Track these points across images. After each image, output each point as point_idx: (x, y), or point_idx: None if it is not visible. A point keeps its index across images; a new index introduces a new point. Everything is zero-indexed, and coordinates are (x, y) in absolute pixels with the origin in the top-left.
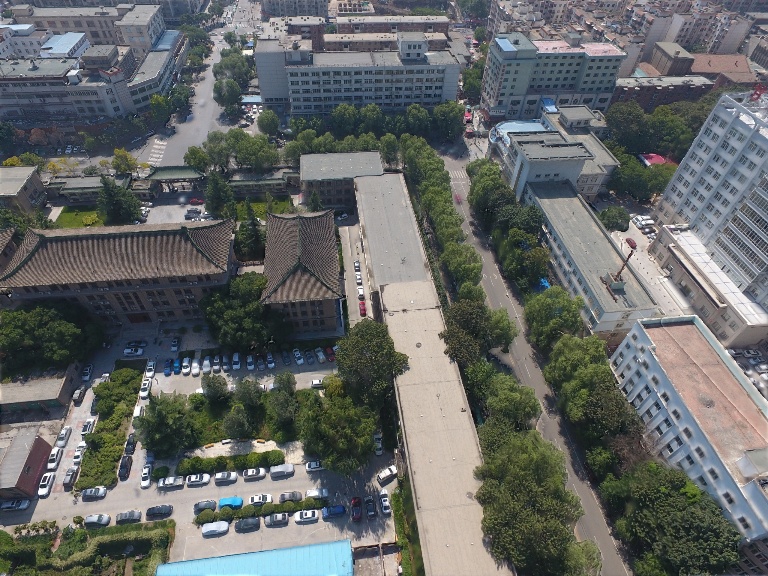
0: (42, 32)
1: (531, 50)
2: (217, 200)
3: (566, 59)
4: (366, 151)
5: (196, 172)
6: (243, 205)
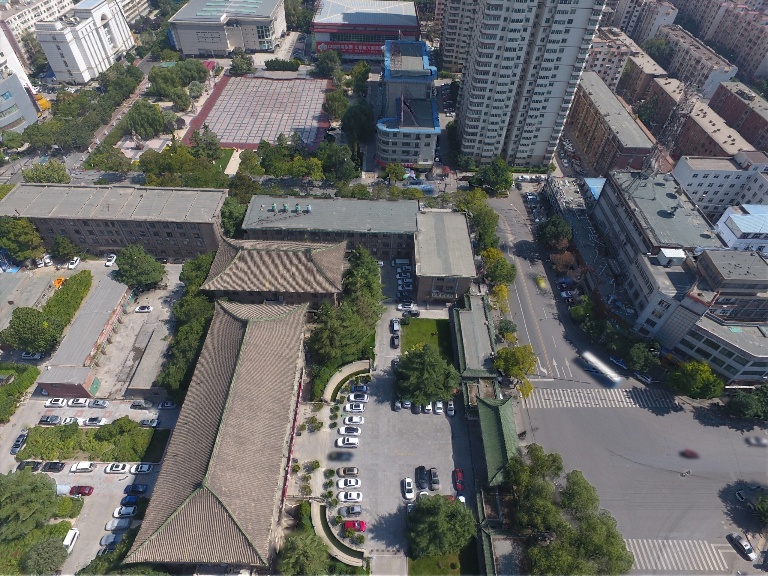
0: None
1: None
2: None
3: None
4: None
5: (499, 470)
6: (454, 567)
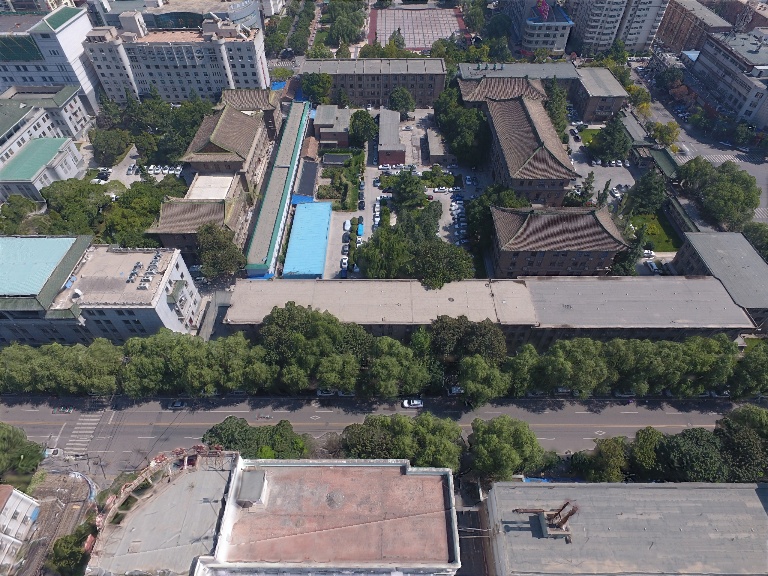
0: None
1: None
2: (635, 189)
3: None
4: None
5: (673, 172)
6: (653, 218)
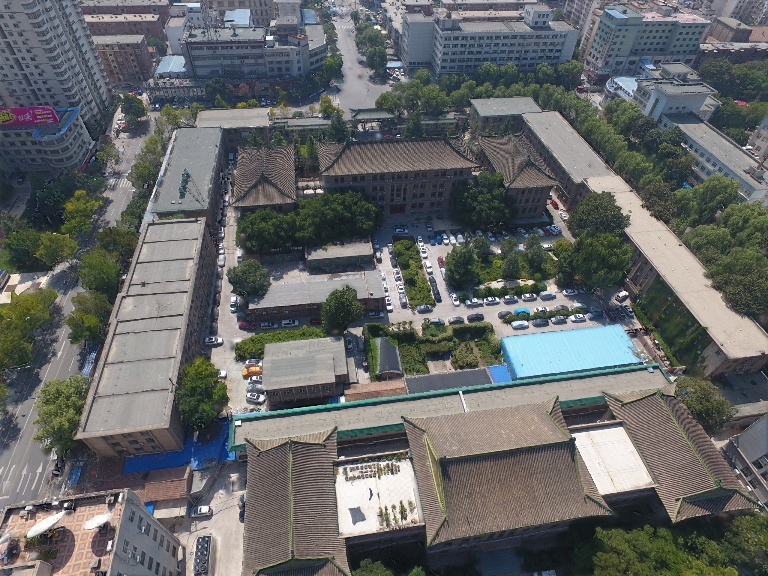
0: (210, 9)
1: (639, 18)
2: (417, 132)
3: (661, 26)
4: (520, 96)
5: (389, 113)
6: None
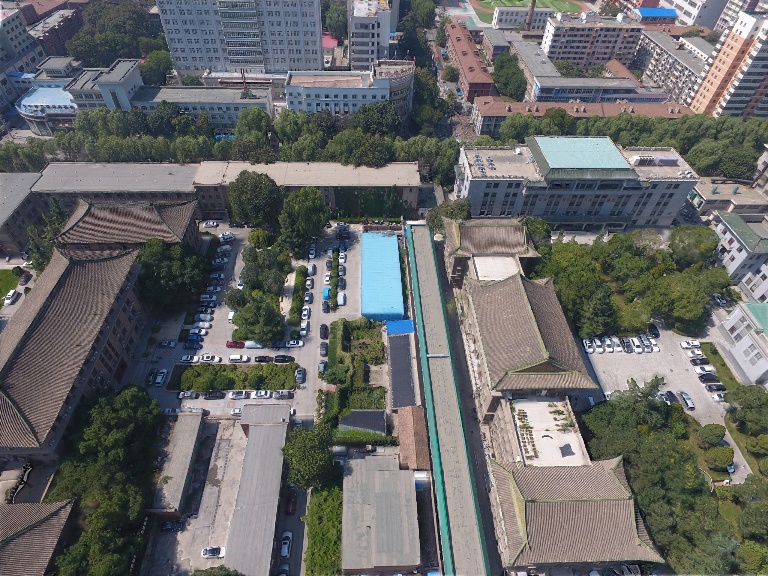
0: None
1: None
2: None
3: None
4: None
5: None
6: None
